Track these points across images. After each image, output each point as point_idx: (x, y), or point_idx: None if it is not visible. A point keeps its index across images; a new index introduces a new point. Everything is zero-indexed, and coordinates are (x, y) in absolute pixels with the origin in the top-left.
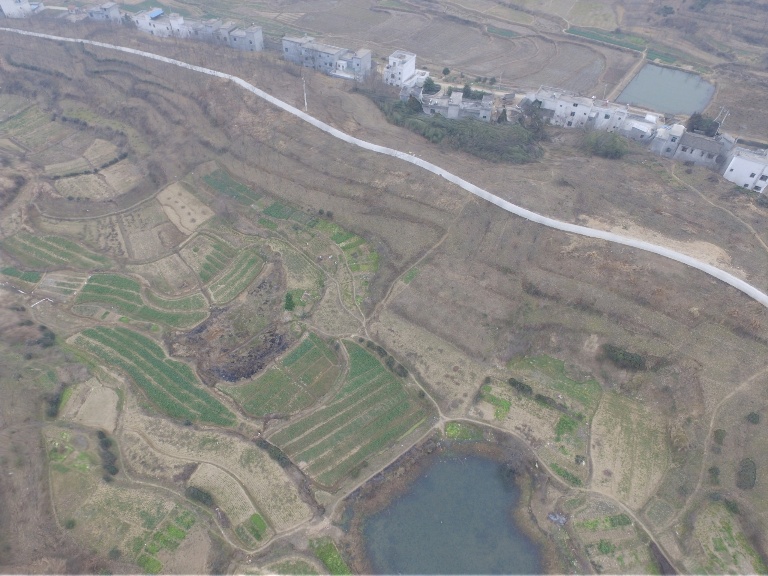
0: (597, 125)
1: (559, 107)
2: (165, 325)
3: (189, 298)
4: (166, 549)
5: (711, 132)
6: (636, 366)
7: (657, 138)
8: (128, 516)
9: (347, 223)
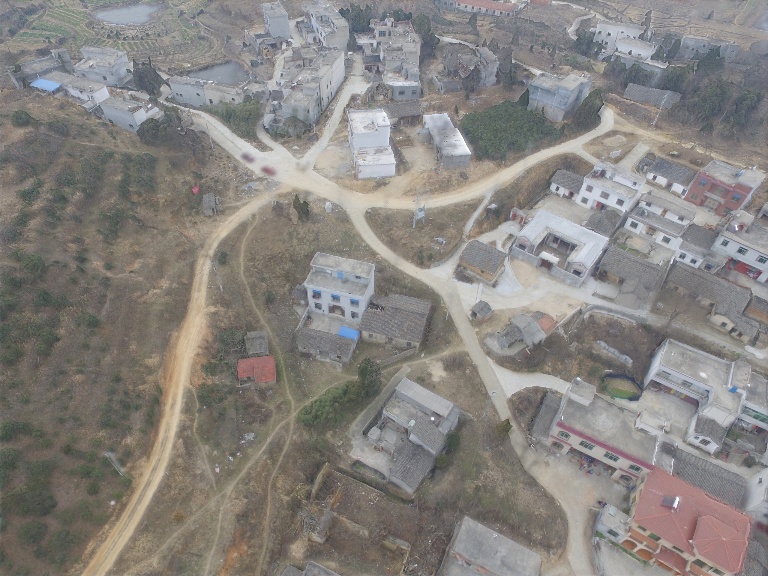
0: None
1: None
2: None
3: None
4: (28, 0)
5: None
6: None
7: None
8: None
9: None
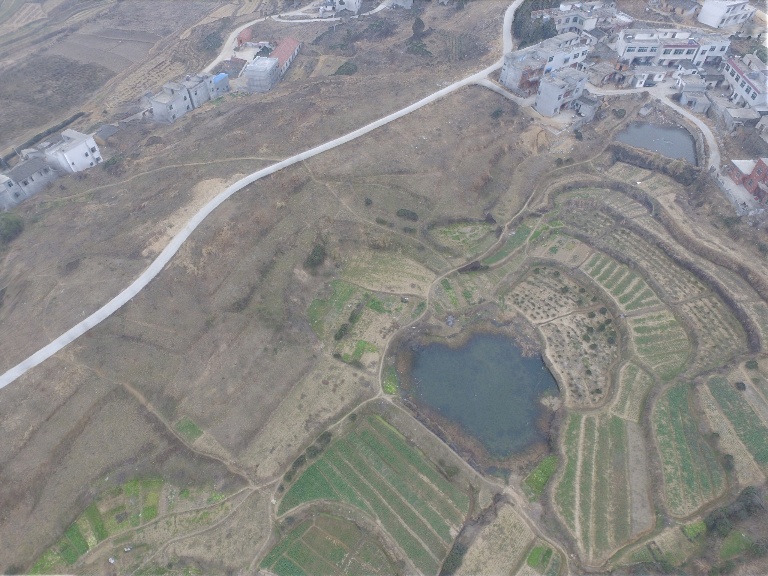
0: None
1: None
2: None
3: None
4: None
5: (0, 163)
6: (323, 252)
7: None
8: None
9: (46, 536)
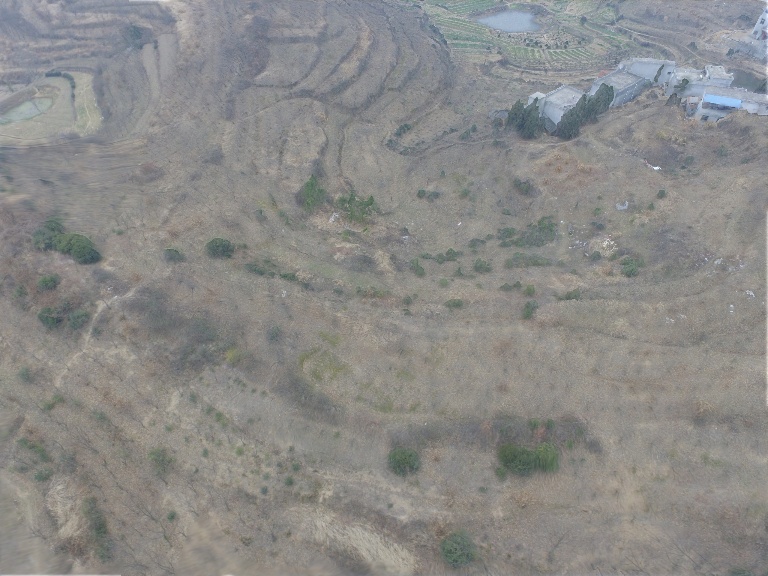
0: None
1: None
2: None
3: None
4: None
5: None
6: None
7: None
8: (394, 6)
9: None
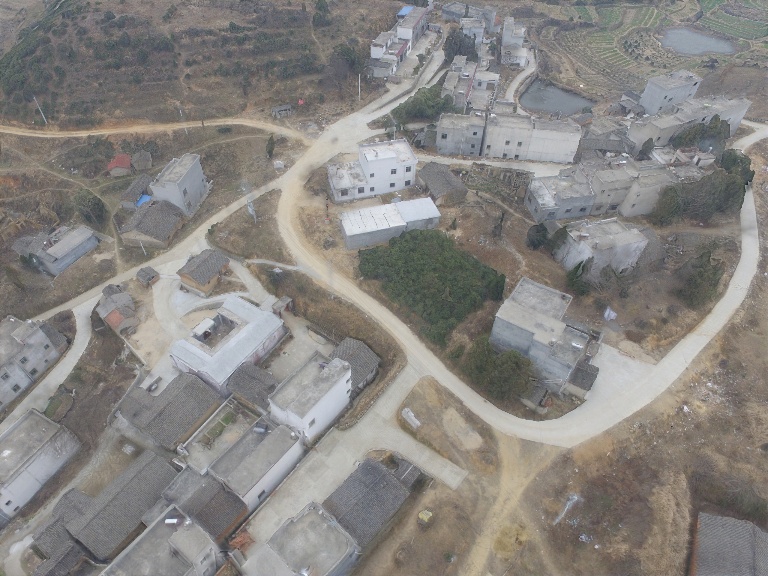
0: None
1: None
2: (742, 2)
3: (764, 6)
4: None
5: None
6: None
7: None
8: None
9: None
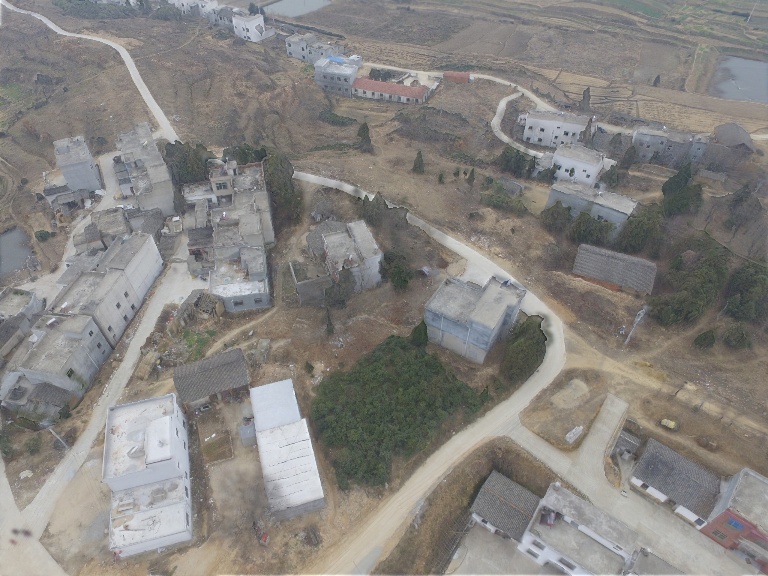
0: (201, 13)
1: (175, 1)
2: None
3: None
4: None
5: (256, 13)
6: (47, 82)
7: (208, 12)
8: None
9: None
